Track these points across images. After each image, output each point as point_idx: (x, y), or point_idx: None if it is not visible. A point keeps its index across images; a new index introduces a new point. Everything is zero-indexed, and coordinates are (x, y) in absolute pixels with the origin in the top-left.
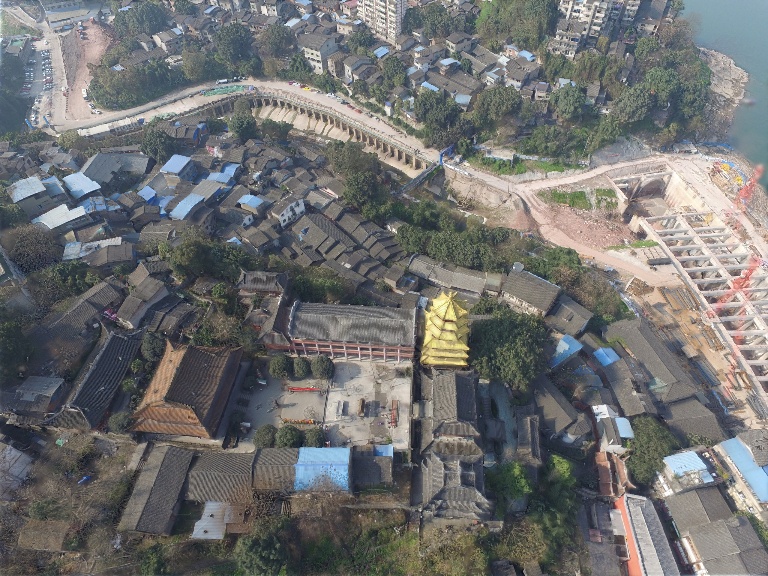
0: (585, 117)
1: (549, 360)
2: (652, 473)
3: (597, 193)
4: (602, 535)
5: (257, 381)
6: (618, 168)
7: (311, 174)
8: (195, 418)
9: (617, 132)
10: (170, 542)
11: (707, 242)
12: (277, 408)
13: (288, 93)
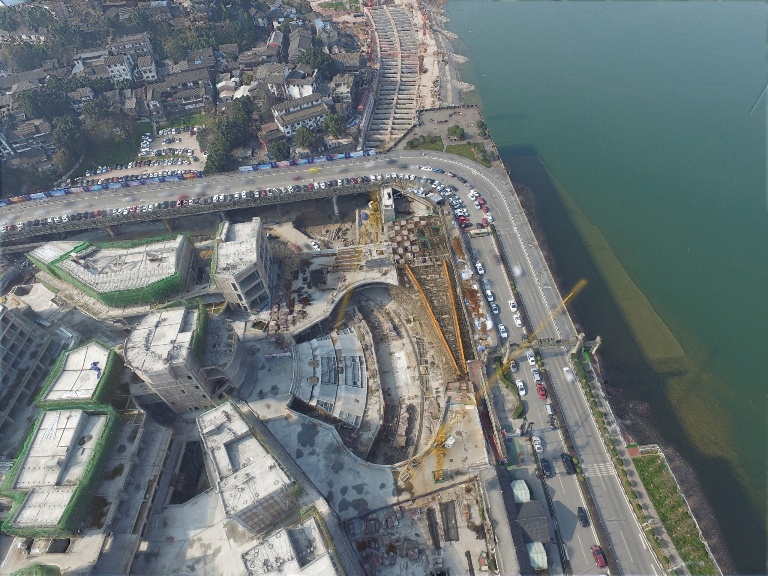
0: None
1: (265, 11)
2: (287, 28)
3: (350, 2)
4: None
5: None
6: None
7: None
8: None
9: None
10: None
11: None
12: None
13: None
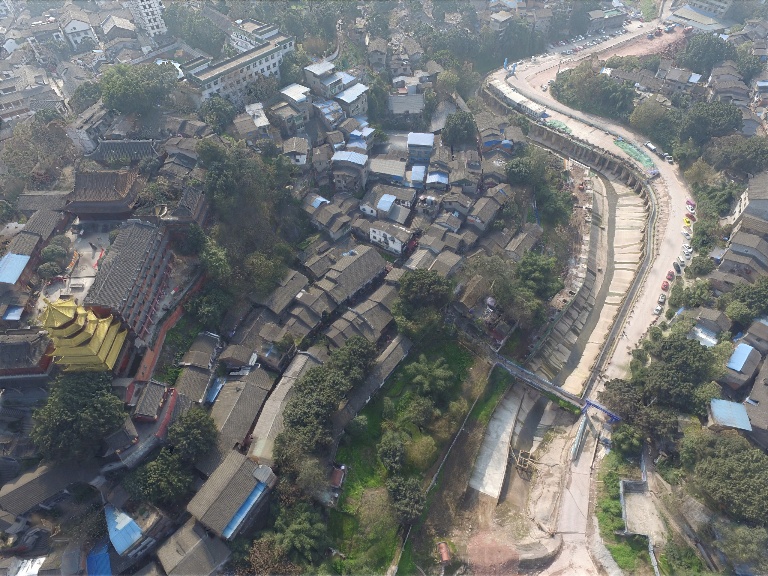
0: None
1: None
2: None
3: None
4: None
5: None
6: None
7: (475, 250)
8: None
9: None
10: (23, 219)
11: None
12: (92, 248)
13: (667, 206)
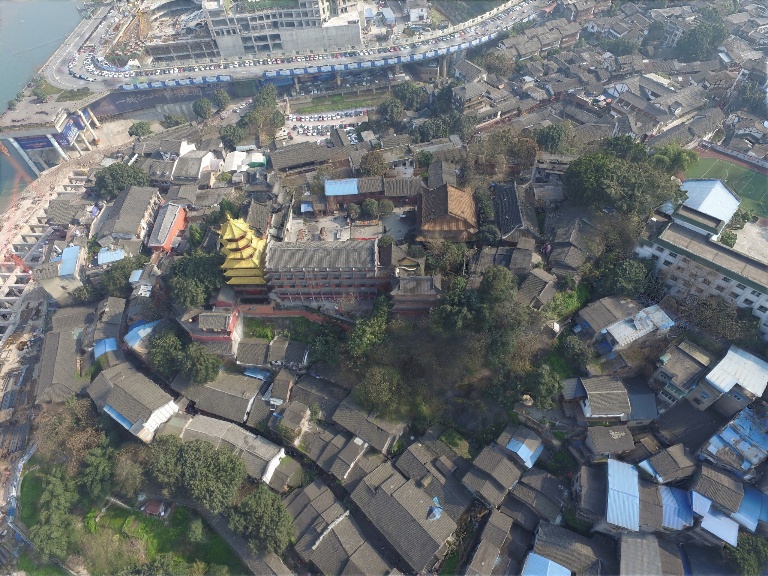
0: None
1: None
2: None
3: None
4: None
5: None
6: None
7: None
8: None
9: None
10: None
11: None
12: None
13: None
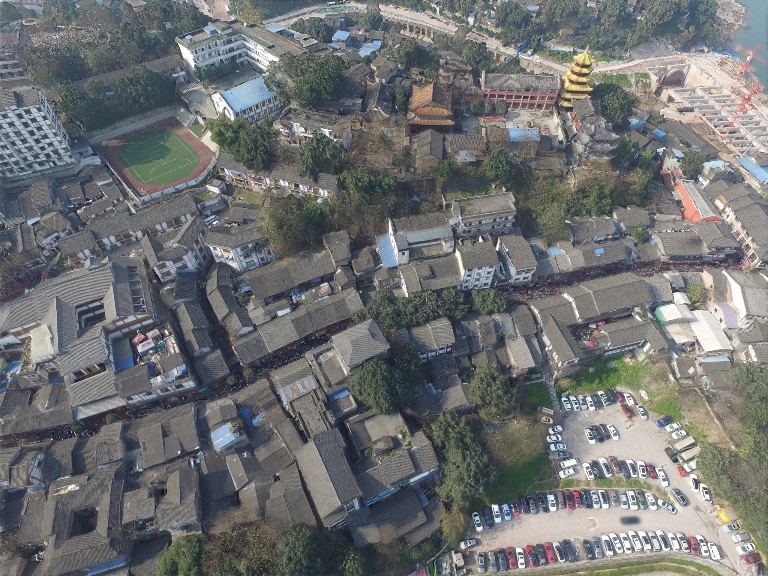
0: (625, 22)
1: None
2: (696, 173)
3: (636, 76)
4: (669, 200)
5: (463, 114)
6: (650, 61)
7: None
8: (447, 112)
9: (650, 31)
10: None
11: None
12: None
13: (386, 12)
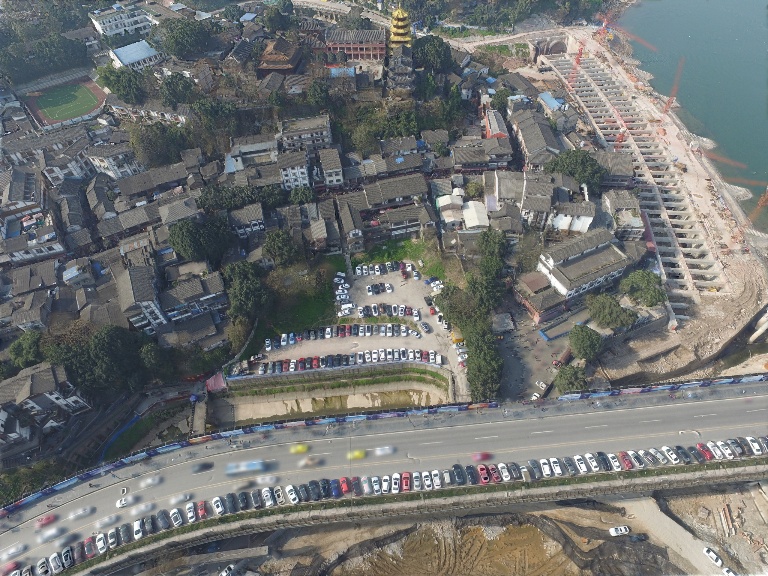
0: (510, 1)
1: (459, 75)
2: (503, 105)
3: (516, 46)
4: (475, 126)
5: (310, 63)
6: (532, 34)
7: None
8: (286, 58)
9: (529, 7)
10: None
11: (583, 68)
12: None
13: (311, 3)
